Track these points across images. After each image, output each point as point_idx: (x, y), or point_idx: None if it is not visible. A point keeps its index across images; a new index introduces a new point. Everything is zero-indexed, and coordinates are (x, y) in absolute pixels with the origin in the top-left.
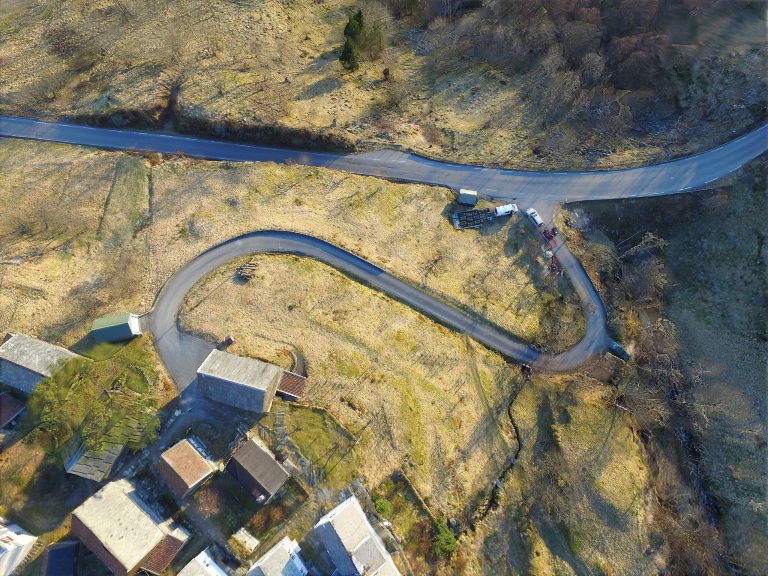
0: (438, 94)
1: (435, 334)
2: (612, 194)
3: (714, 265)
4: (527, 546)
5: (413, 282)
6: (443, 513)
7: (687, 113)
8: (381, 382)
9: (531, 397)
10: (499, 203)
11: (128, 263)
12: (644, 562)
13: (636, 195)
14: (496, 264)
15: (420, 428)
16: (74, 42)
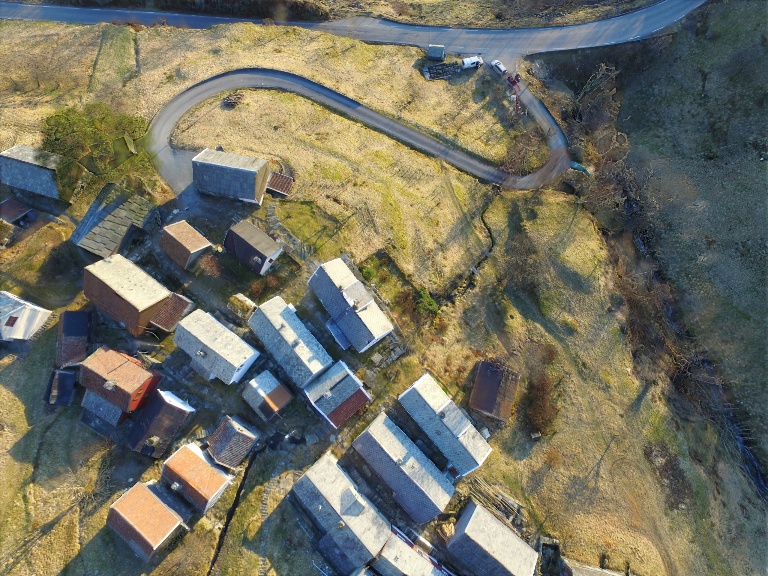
0: None
1: (411, 155)
2: (569, 46)
3: (665, 106)
4: (502, 310)
5: (389, 114)
6: (425, 287)
7: None
8: (363, 186)
9: (502, 206)
10: None
11: (120, 105)
12: (606, 318)
13: (591, 45)
14: (465, 107)
15: (401, 222)
16: None
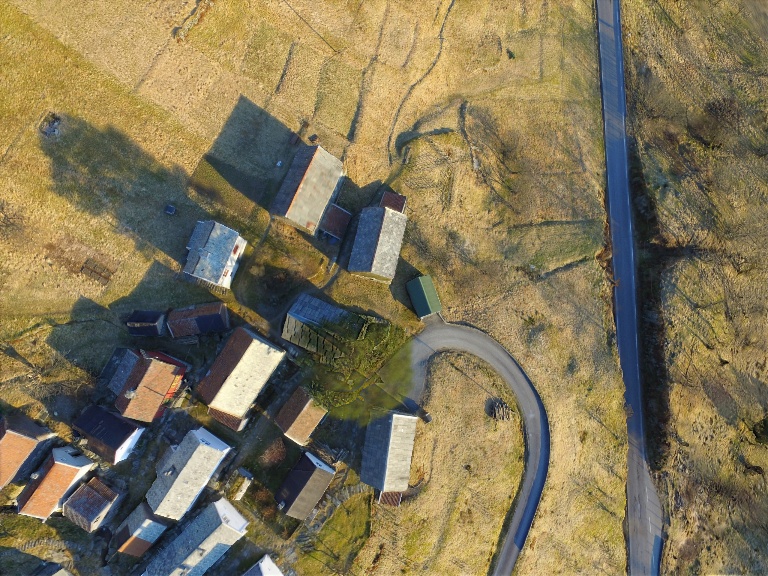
0: (741, 538)
1: None
2: None
3: None
4: None
5: None
6: None
7: None
8: None
9: None
10: None
11: (490, 274)
12: None
13: None
14: None
15: None
16: (721, 106)
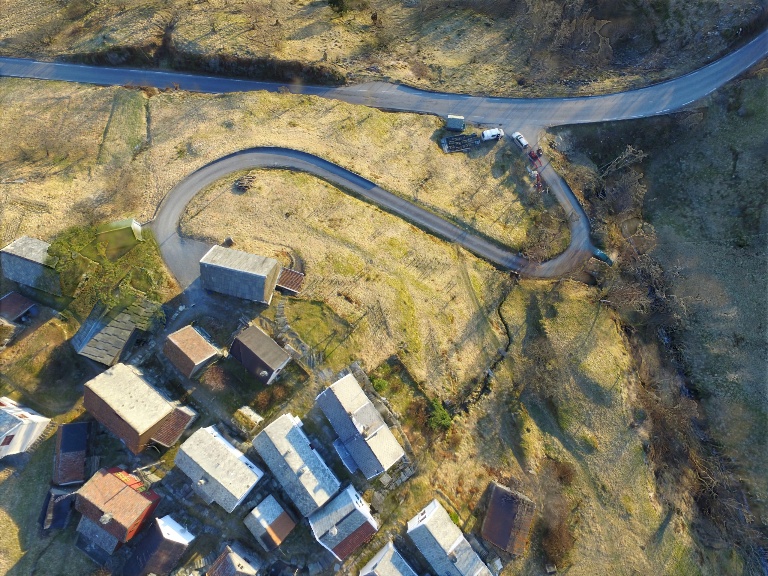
0: (425, 36)
1: (427, 242)
2: (594, 118)
3: (692, 183)
4: (518, 423)
5: (405, 195)
6: (438, 395)
7: (664, 46)
8: (376, 280)
9: (520, 298)
10: (486, 129)
11: (129, 182)
12: (628, 435)
13: (617, 118)
14: (484, 184)
15: (414, 321)
16: None
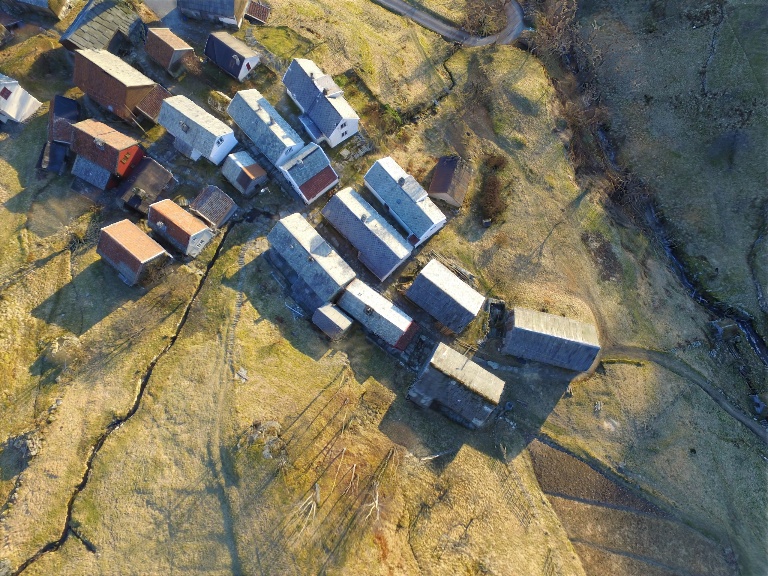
0: None
1: (380, 9)
2: None
3: None
4: (459, 127)
5: None
6: None
7: None
8: (334, 23)
9: (462, 57)
10: None
11: None
12: (552, 137)
13: None
14: None
15: (369, 55)
16: None
